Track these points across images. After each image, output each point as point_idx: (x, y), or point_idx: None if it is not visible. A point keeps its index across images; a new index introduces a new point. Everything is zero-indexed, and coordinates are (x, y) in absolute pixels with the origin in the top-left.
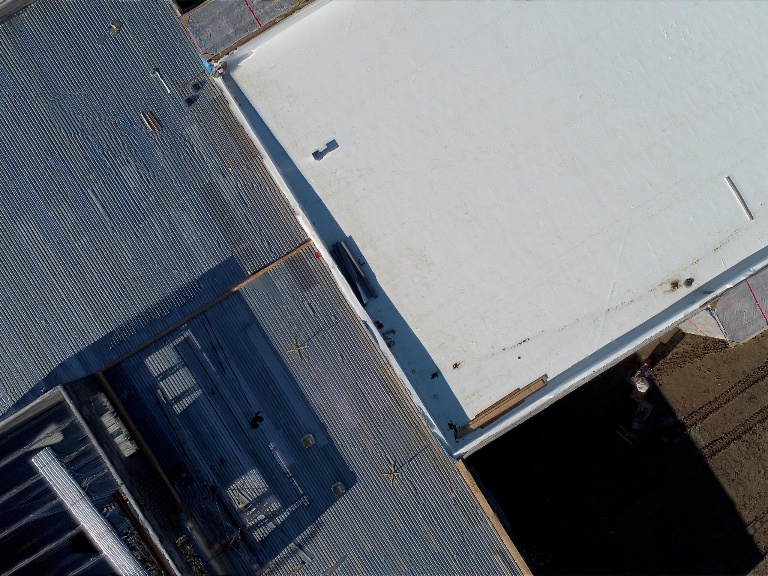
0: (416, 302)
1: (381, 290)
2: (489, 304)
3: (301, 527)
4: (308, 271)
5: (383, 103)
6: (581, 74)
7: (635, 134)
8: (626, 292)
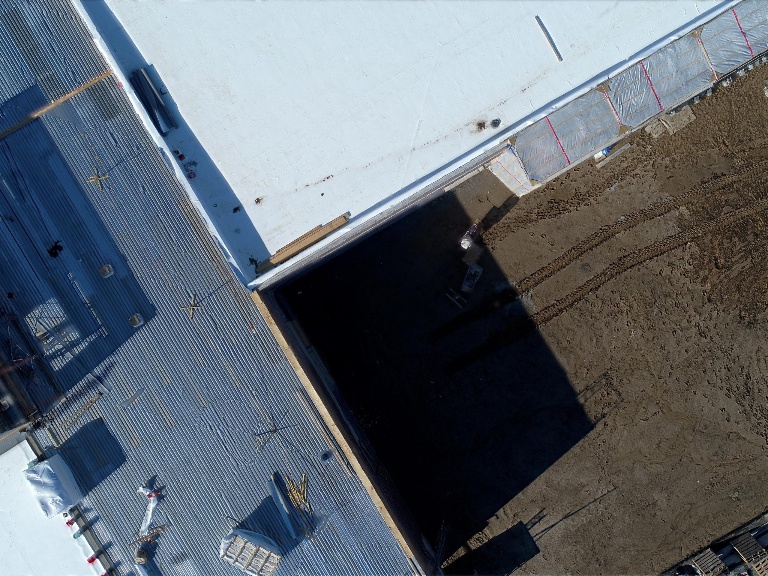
0: (218, 134)
1: (183, 121)
2: (292, 139)
3: (99, 358)
4: (111, 101)
5: None
6: None
7: None
8: (432, 131)
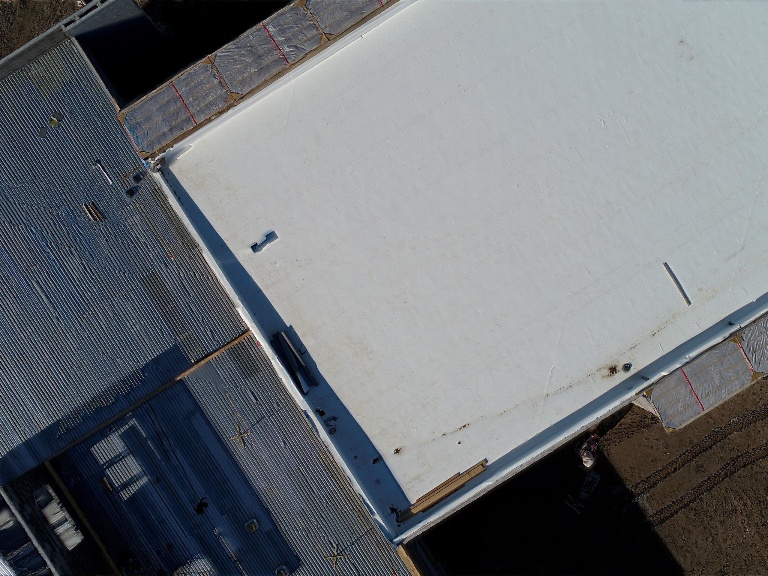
0: (357, 389)
1: (322, 378)
2: (429, 391)
3: None
4: (250, 359)
5: (321, 194)
6: (518, 163)
7: (573, 222)
8: (565, 377)
